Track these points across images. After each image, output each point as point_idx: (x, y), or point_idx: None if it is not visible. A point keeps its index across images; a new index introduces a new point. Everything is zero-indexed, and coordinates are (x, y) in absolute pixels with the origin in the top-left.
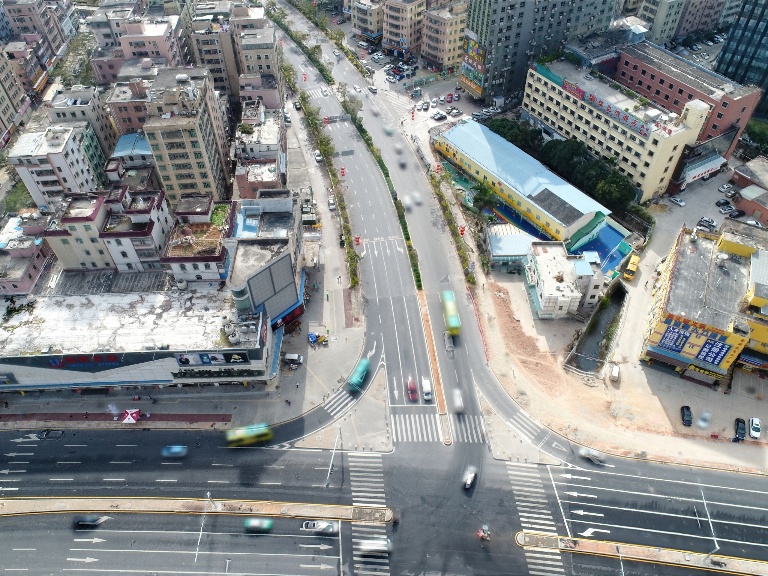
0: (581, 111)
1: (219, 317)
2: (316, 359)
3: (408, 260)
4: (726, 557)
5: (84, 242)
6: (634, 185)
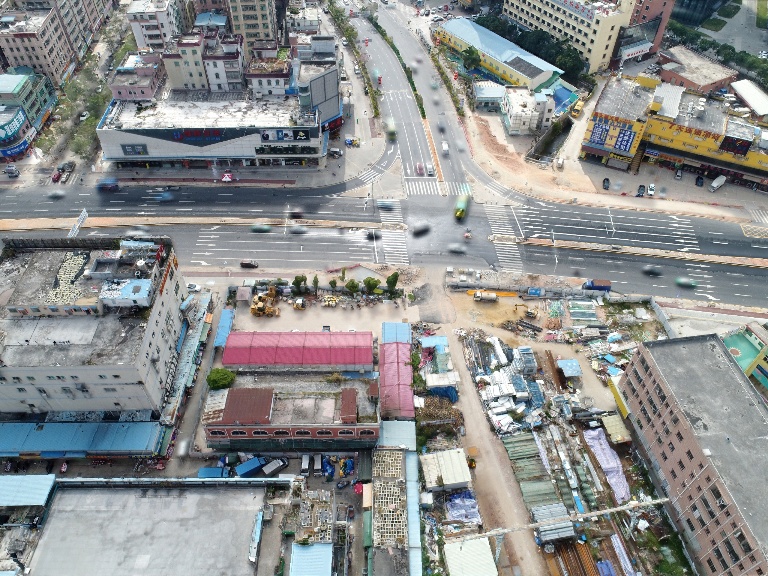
0: (546, 7)
1: (287, 114)
2: (352, 153)
3: (415, 103)
4: (622, 246)
5: (190, 65)
6: (584, 60)
